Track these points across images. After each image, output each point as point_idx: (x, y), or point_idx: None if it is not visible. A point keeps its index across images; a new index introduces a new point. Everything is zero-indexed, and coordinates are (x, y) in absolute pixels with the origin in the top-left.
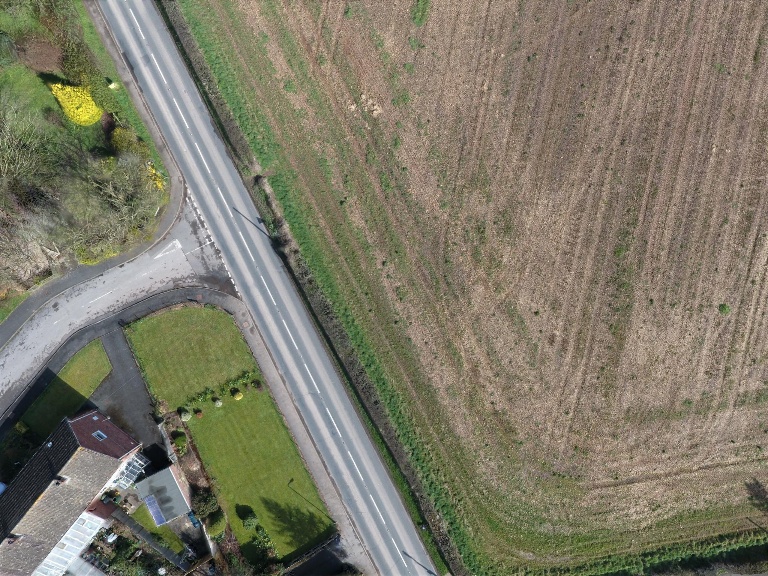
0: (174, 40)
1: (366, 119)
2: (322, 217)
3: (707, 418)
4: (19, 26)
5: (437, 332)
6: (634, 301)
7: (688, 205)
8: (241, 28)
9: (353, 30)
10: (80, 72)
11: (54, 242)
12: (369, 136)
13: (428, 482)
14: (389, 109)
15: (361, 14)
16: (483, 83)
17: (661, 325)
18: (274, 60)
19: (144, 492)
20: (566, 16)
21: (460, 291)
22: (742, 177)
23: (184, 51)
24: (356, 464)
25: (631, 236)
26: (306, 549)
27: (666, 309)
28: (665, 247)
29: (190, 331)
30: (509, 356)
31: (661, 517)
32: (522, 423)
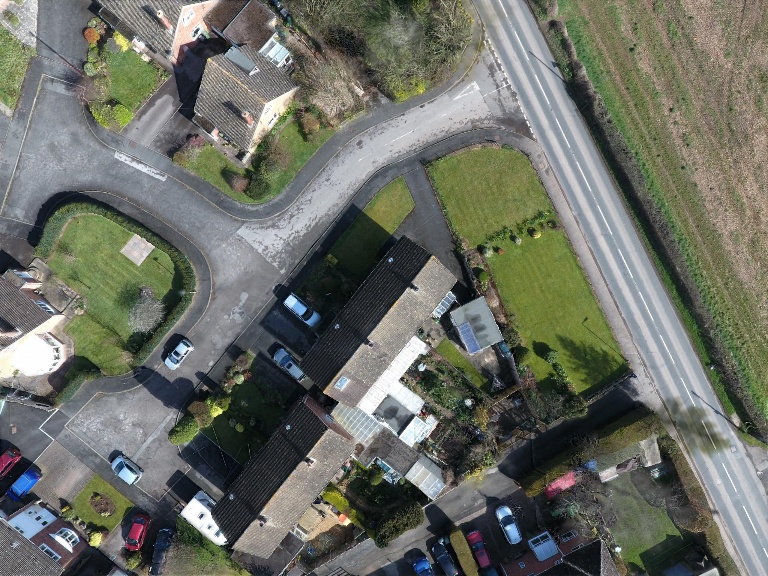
0: None
1: None
2: (612, 63)
3: None
4: None
5: (721, 178)
6: None
7: None
8: None
9: None
10: None
11: (359, 81)
12: None
13: None
14: None
15: None
16: None
17: None
18: None
19: (459, 320)
20: None
21: (743, 139)
22: None
23: None
24: (647, 305)
25: None
26: (600, 386)
27: None
28: None
29: (488, 171)
30: None
31: None
32: None
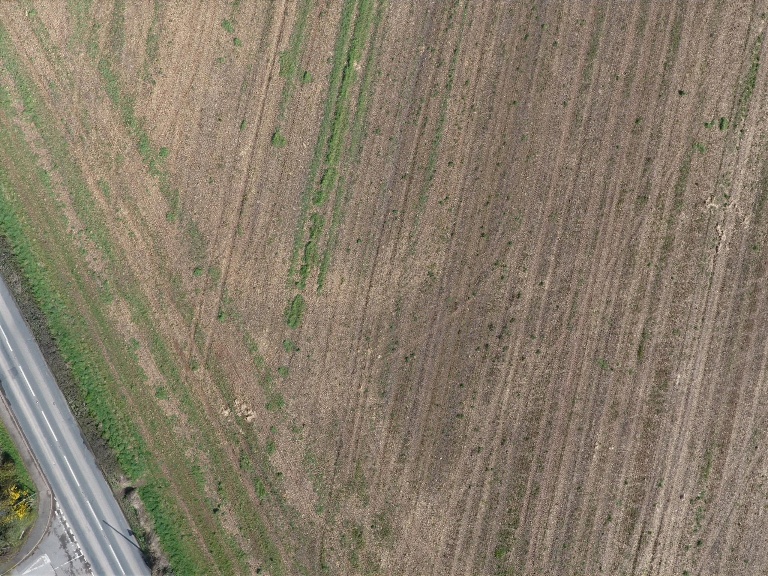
0: None
1: (240, 424)
2: (195, 525)
3: None
4: None
5: None
6: None
7: (571, 504)
8: (112, 336)
9: (227, 334)
10: None
11: None
12: (243, 441)
13: None
14: (263, 414)
15: (235, 317)
16: (360, 385)
17: None
18: (146, 367)
19: None
20: (444, 315)
21: None
22: (626, 474)
23: None
24: None
25: (512, 537)
26: None
27: None
28: (547, 547)
29: None
30: None
31: None
32: None
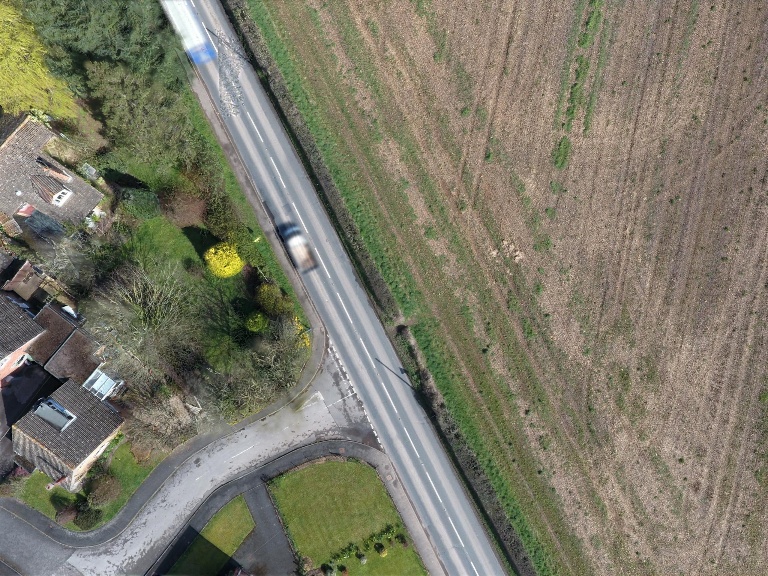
0: (315, 188)
1: (508, 265)
2: (464, 366)
3: None
4: (159, 176)
5: (581, 481)
6: None
7: None
8: (382, 174)
9: (494, 175)
10: (227, 229)
11: (196, 397)
12: (511, 282)
13: None
14: (531, 255)
15: (502, 158)
16: (626, 227)
17: None
18: (415, 206)
19: None
20: (709, 158)
21: (603, 439)
22: None
23: (326, 200)
24: None
25: None
26: None
27: None
28: None
29: (333, 485)
30: (653, 504)
31: None
32: (667, 572)
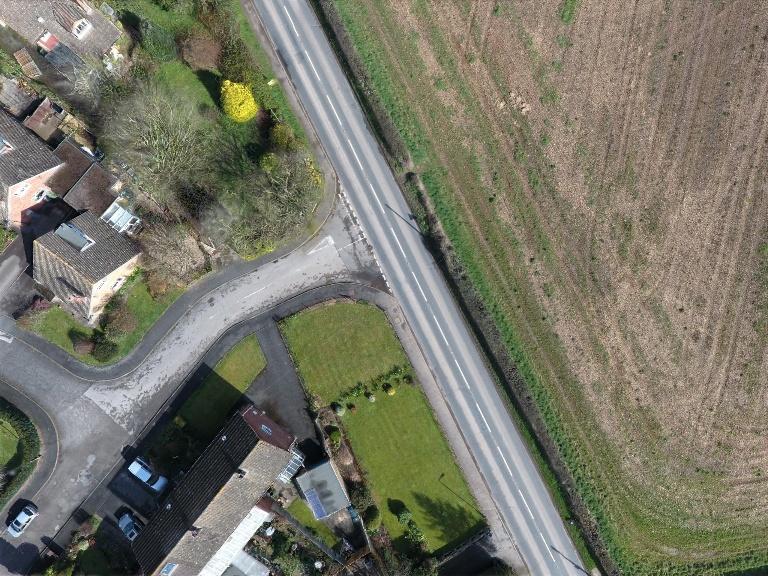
0: (327, 37)
1: (515, 117)
2: (471, 214)
3: None
4: (175, 23)
5: (583, 329)
6: None
7: None
8: (392, 26)
9: (502, 28)
10: (241, 69)
11: (210, 238)
12: (517, 133)
13: (575, 477)
14: (537, 107)
15: (510, 12)
16: (630, 81)
17: None
18: (425, 58)
19: (305, 486)
20: (712, 15)
21: (606, 288)
22: None
23: (338, 48)
24: (505, 459)
25: None
26: (457, 544)
27: None
28: None
29: (343, 327)
30: (654, 353)
31: None
32: (666, 419)
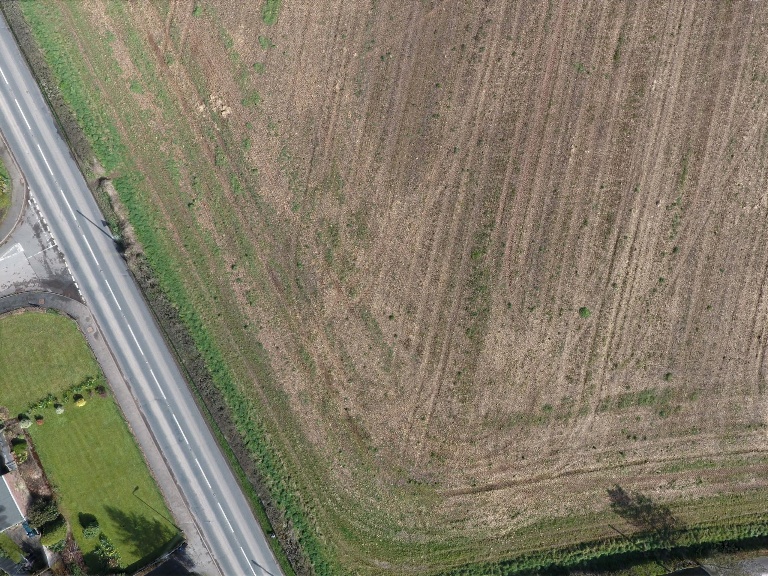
0: (16, 40)
1: (215, 120)
2: (170, 220)
3: (568, 424)
4: None
5: (289, 337)
6: (491, 305)
7: (547, 207)
8: (86, 27)
9: (202, 29)
10: None
11: None
12: (218, 137)
13: (279, 490)
14: (239, 110)
15: (210, 13)
16: (335, 83)
17: (519, 329)
18: (120, 60)
19: None
20: (421, 14)
21: (312, 295)
22: (602, 178)
23: None
24: (204, 471)
25: (488, 238)
26: (151, 558)
27: (524, 313)
28: (523, 250)
29: (32, 336)
30: (363, 361)
31: (521, 525)
32: (377, 429)
